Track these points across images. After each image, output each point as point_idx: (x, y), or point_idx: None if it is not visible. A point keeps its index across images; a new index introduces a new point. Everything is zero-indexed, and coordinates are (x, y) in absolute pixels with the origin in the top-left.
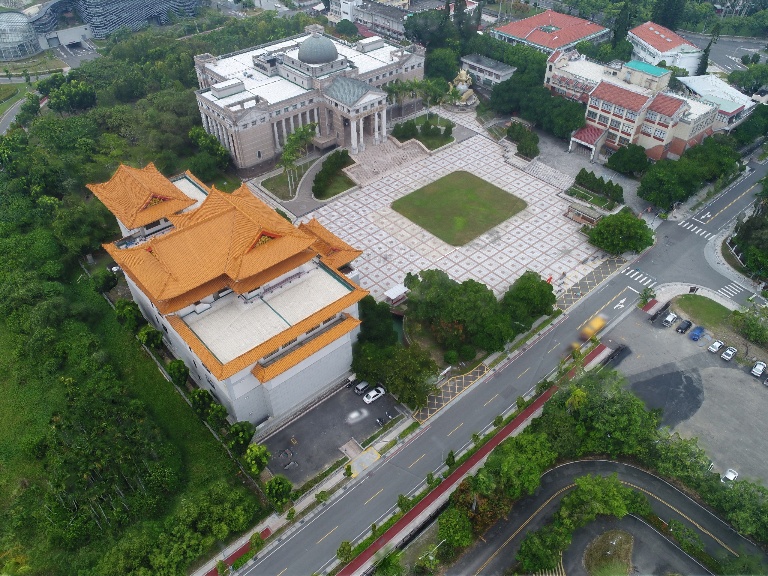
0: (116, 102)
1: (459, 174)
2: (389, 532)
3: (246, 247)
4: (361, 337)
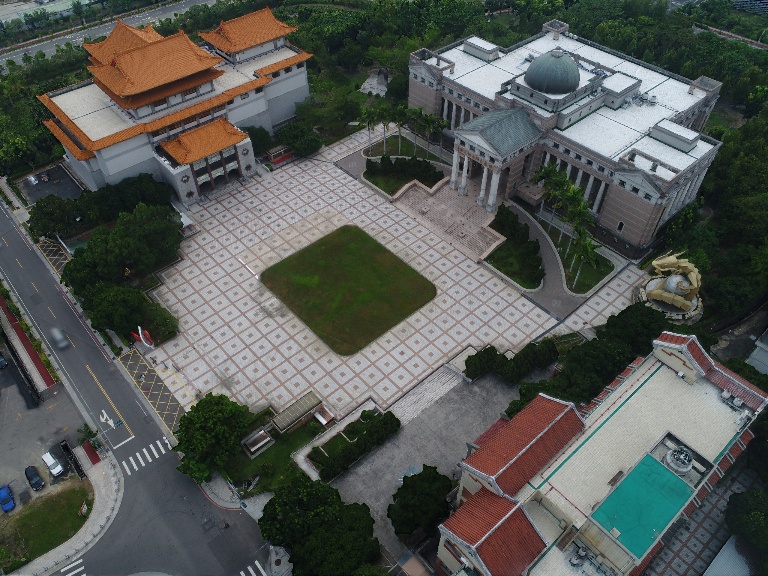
0: (534, 30)
1: (426, 288)
2: None
3: None
4: None
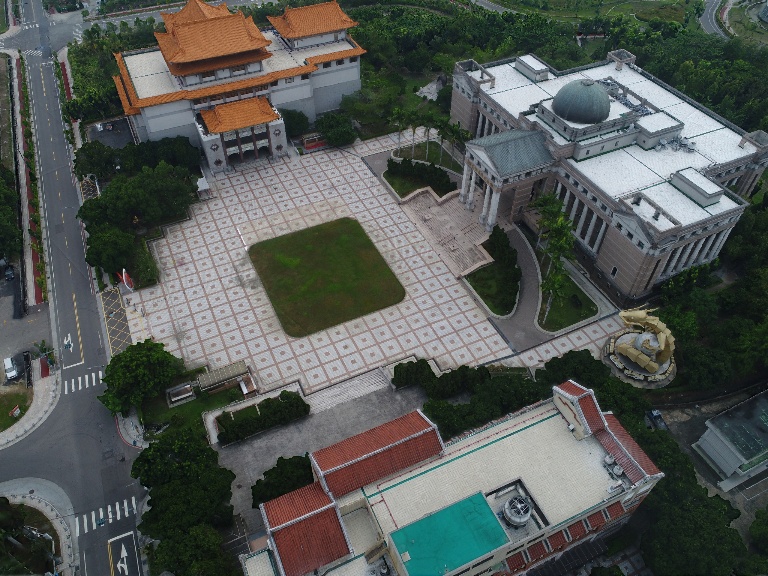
0: None
1: (395, 291)
2: None
3: None
4: None
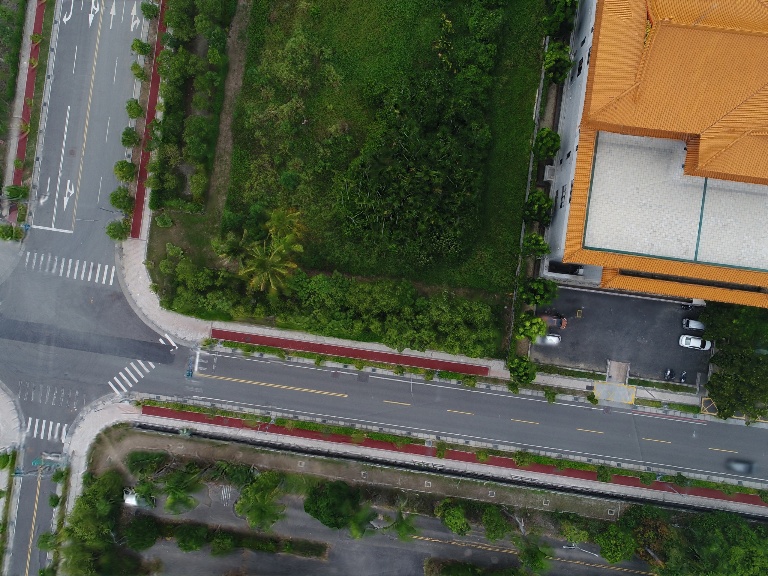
0: None
1: None
2: (570, 470)
3: (764, 129)
4: None
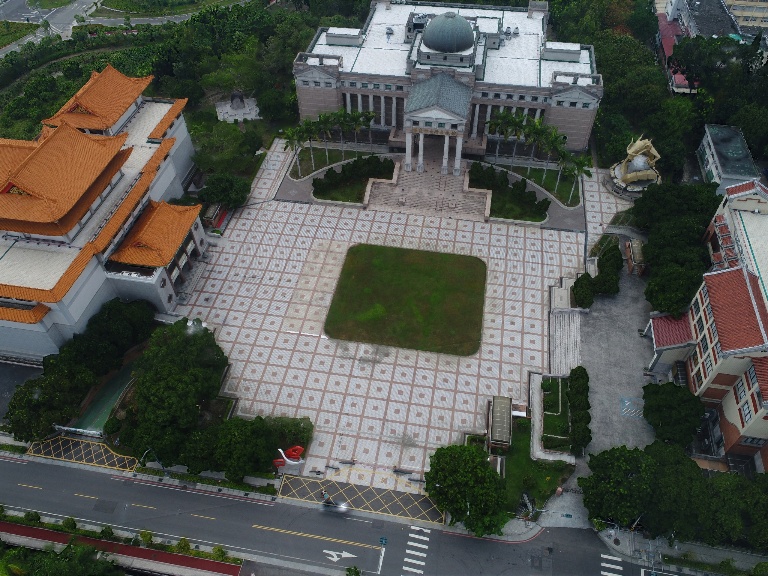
0: (327, 11)
1: (472, 263)
2: None
3: None
4: (74, 338)
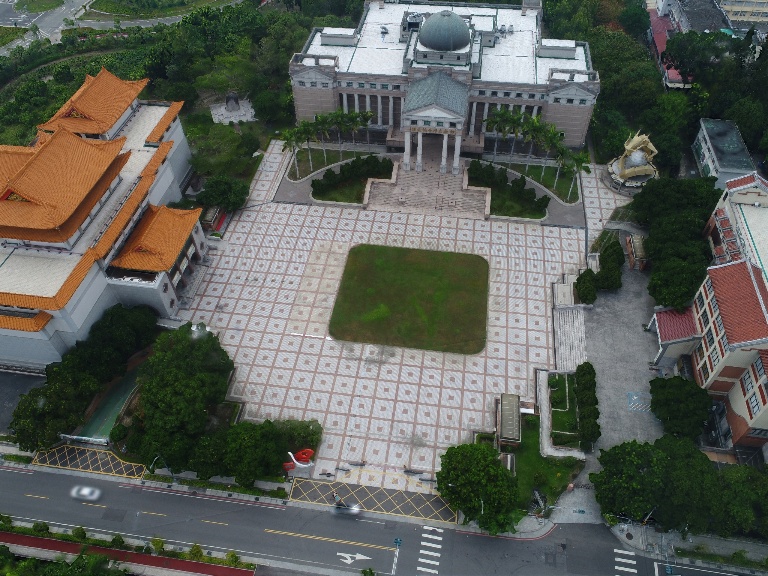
0: (319, 11)
1: (474, 261)
2: None
3: None
4: (77, 346)
